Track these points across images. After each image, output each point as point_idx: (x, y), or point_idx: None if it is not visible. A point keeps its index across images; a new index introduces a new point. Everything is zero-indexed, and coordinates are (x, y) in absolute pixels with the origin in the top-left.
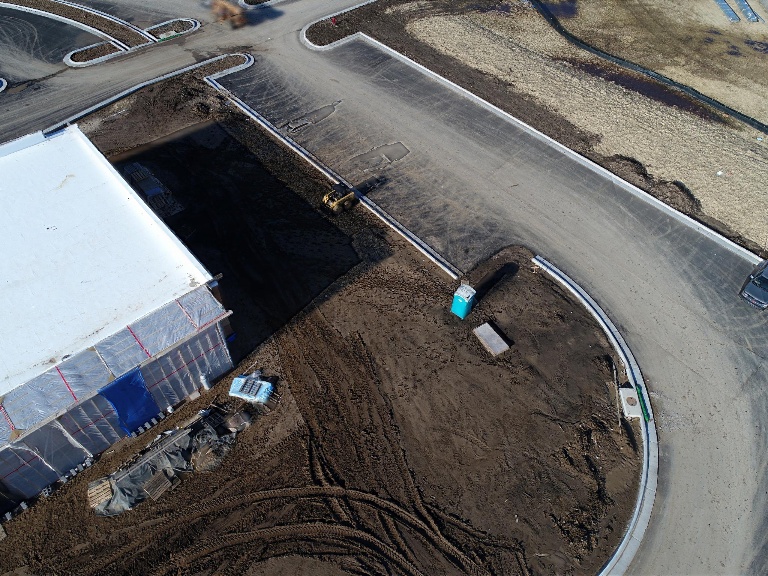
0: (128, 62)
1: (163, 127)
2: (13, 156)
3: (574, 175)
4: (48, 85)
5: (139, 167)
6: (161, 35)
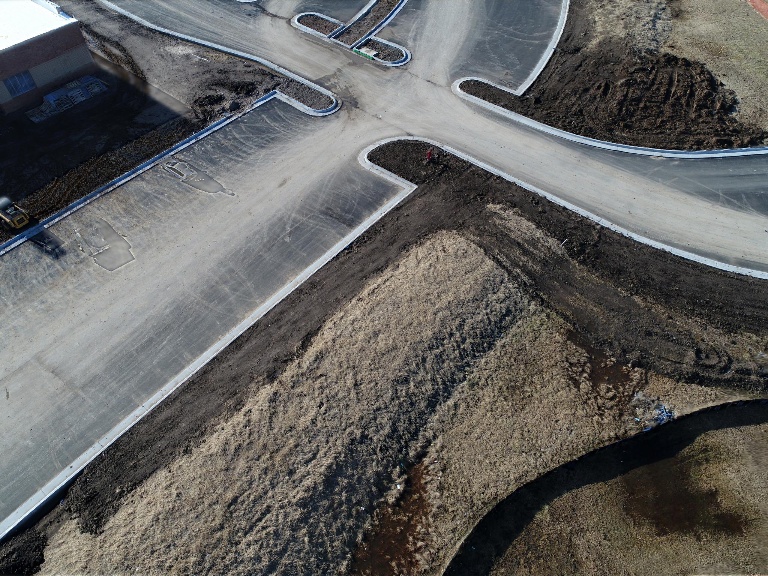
0: (305, 44)
1: (177, 86)
2: (42, 9)
3: (8, 481)
4: (256, 18)
5: (86, 82)
6: (365, 48)
